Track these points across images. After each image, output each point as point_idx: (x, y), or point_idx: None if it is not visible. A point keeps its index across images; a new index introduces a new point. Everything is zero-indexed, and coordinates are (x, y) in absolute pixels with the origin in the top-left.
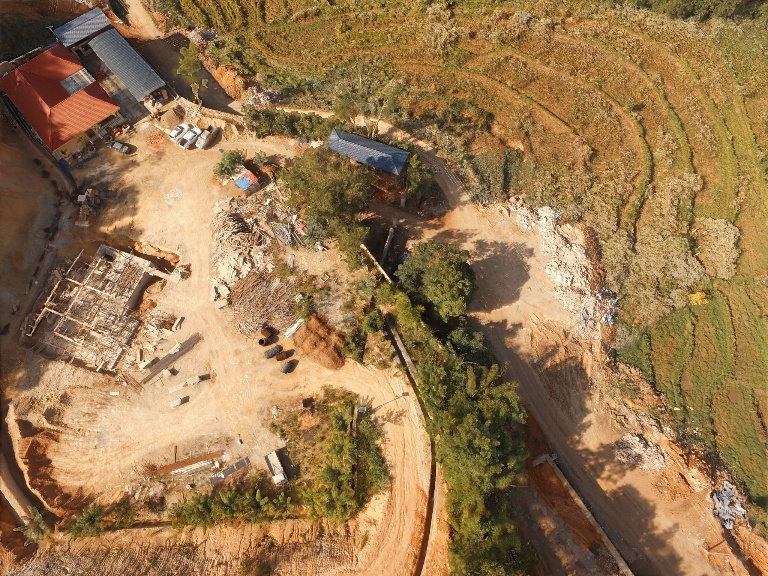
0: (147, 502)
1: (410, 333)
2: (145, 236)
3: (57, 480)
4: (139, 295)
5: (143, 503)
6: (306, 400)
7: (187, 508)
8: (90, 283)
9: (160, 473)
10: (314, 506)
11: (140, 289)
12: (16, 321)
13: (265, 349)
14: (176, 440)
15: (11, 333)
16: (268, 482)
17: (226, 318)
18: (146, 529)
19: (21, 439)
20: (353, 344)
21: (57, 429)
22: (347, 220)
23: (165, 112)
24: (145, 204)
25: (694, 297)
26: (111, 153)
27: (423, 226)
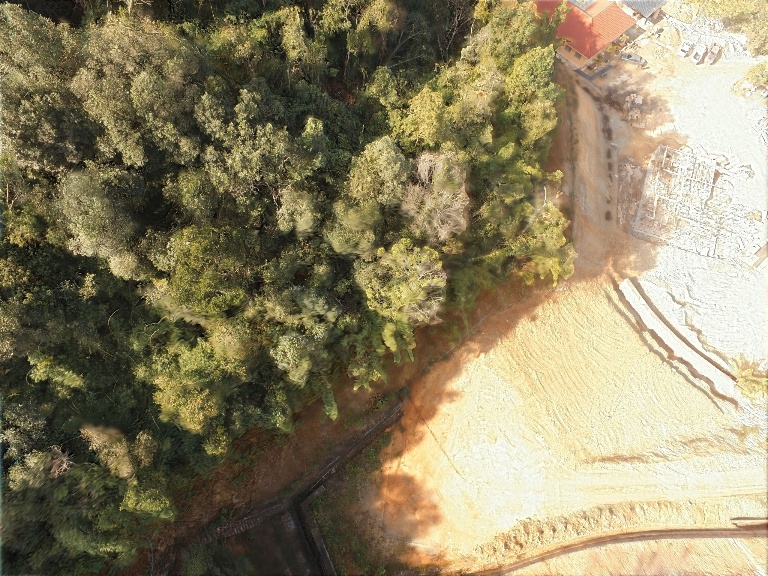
0: None
1: None
2: (693, 139)
3: (715, 347)
4: None
5: None
6: None
7: None
8: None
9: None
10: None
11: None
12: (614, 209)
13: None
14: None
15: (615, 219)
16: None
17: None
18: None
19: (678, 309)
20: None
21: (695, 303)
22: None
23: None
24: (678, 111)
25: None
26: (624, 65)
27: None
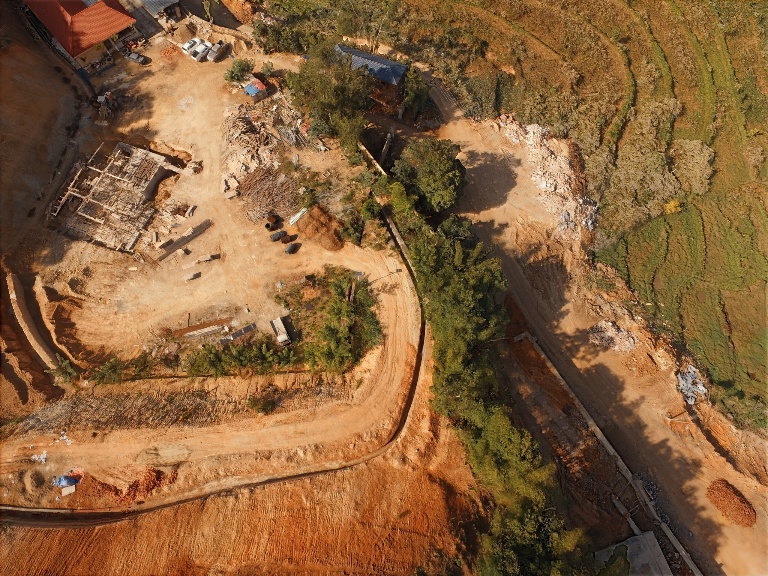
0: (163, 359)
1: (404, 221)
2: (160, 136)
3: (81, 340)
4: (154, 188)
5: (159, 360)
6: (308, 276)
7: (200, 356)
8: (109, 176)
9: (175, 335)
10: (315, 358)
11: (155, 182)
12: (41, 205)
13: (271, 234)
14: (189, 308)
15: (37, 216)
16: (273, 344)
17: (235, 207)
18: (162, 379)
19: (48, 303)
20: (352, 228)
21: (80, 297)
22: (348, 116)
23: (178, 28)
24: (160, 109)
25: (668, 206)
26: (127, 64)
27: (419, 137)
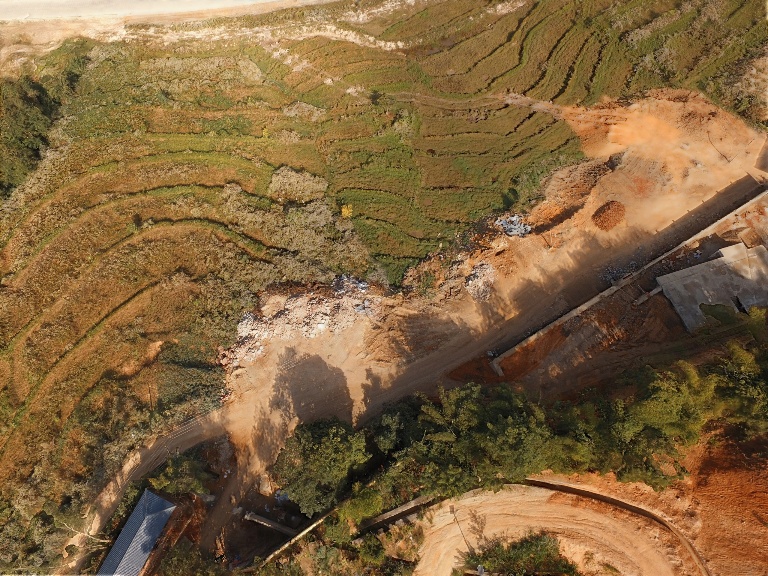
0: None
1: None
2: None
3: None
4: None
5: None
6: None
7: None
8: None
9: None
10: None
11: None
12: None
13: None
14: None
15: None
16: None
17: None
18: None
19: None
20: None
21: None
22: None
23: None
24: None
25: (345, 214)
26: None
27: (243, 472)
